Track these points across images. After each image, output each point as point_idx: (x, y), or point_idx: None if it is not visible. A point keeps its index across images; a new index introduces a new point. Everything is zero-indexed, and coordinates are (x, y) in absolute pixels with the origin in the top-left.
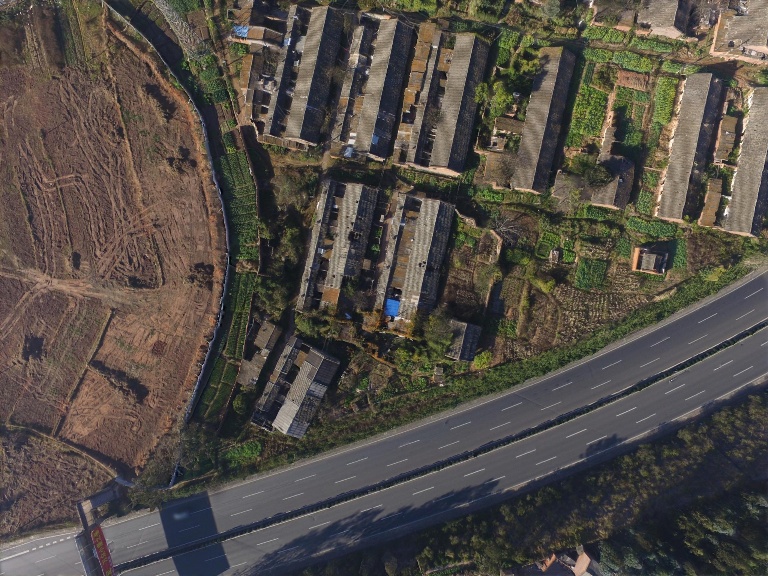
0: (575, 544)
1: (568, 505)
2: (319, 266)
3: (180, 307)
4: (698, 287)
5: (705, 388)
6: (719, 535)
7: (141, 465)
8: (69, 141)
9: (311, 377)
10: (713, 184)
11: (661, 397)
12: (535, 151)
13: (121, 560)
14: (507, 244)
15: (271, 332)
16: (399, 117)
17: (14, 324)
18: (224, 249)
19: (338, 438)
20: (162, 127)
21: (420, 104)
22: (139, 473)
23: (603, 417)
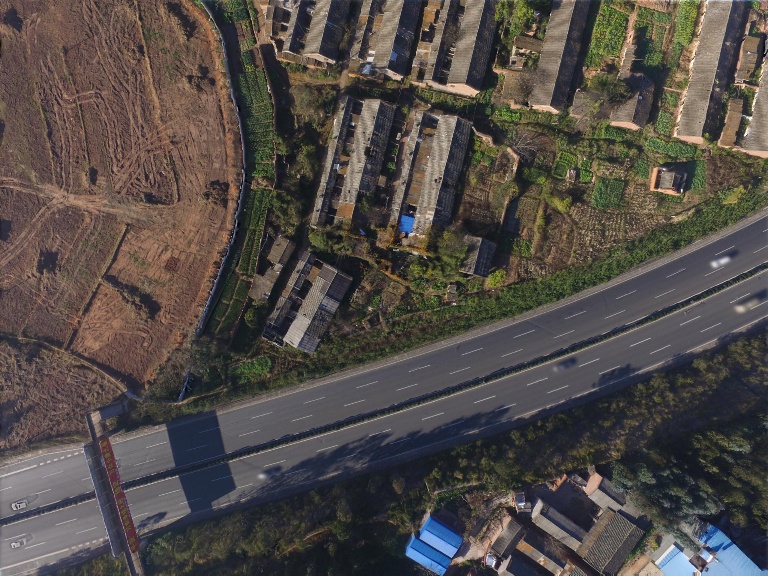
0: (587, 465)
1: (580, 430)
2: (334, 182)
3: (194, 224)
4: (716, 213)
5: (721, 320)
6: (735, 454)
7: (151, 380)
8: (90, 58)
9: (324, 291)
10: (734, 104)
11: (676, 328)
12: (554, 68)
13: (128, 477)
14: (524, 161)
15: (285, 247)
16: (418, 36)
17: (30, 239)
18: (240, 166)
19: (349, 357)
20: (182, 45)
21: (439, 22)
22: (149, 387)
23: (617, 347)
